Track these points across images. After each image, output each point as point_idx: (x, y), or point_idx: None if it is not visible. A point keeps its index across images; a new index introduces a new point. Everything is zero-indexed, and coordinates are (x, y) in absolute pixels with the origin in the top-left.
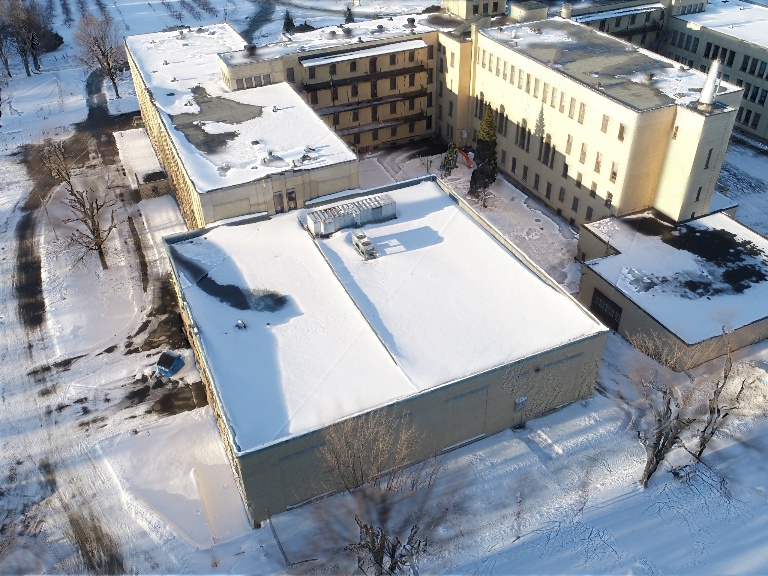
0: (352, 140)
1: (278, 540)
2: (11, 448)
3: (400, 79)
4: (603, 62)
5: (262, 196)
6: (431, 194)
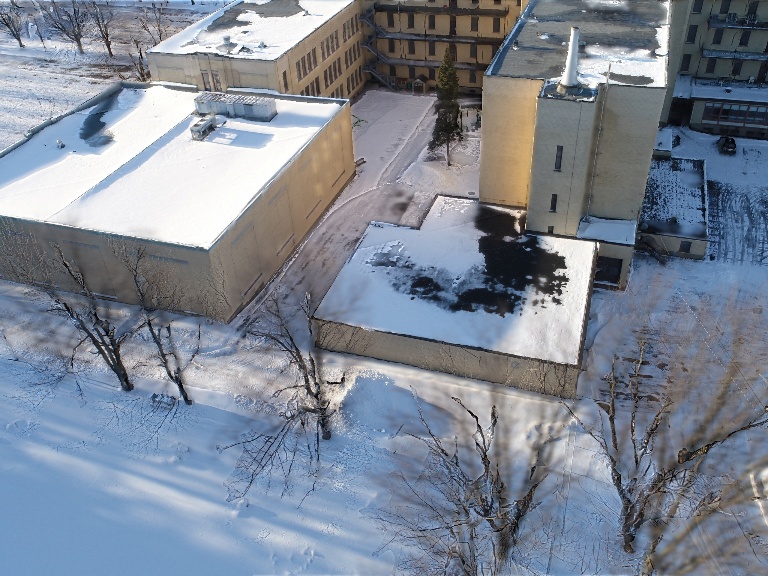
0: (427, 74)
1: None
2: None
3: (482, 21)
4: (588, 28)
5: (193, 70)
6: (322, 114)
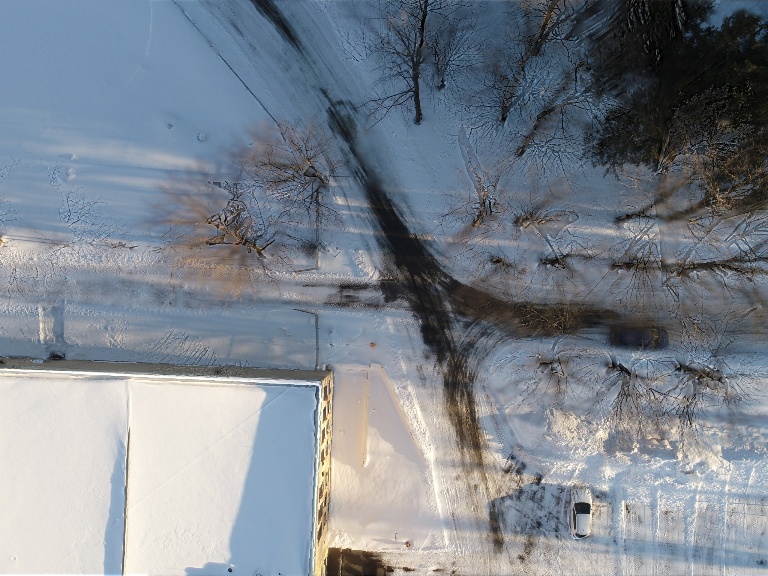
0: None
1: (317, 344)
2: None
3: None
4: None
5: None
6: None
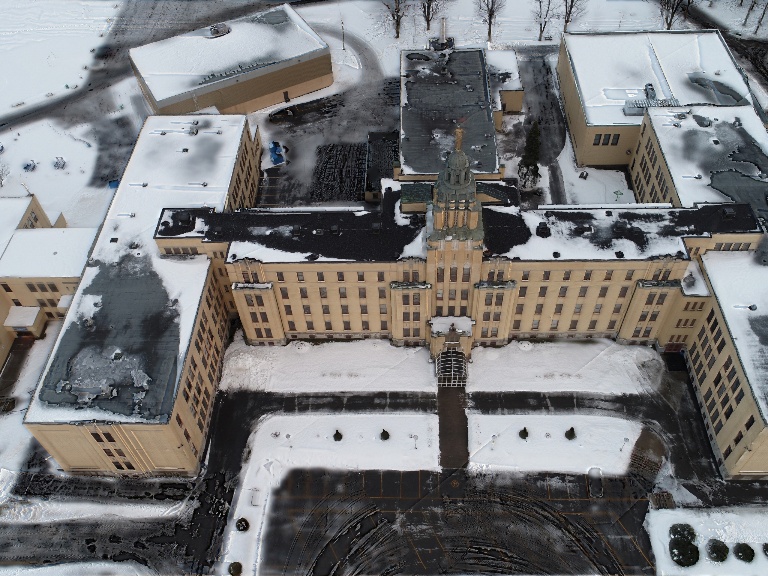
0: None
1: None
2: None
3: None
4: (447, 98)
5: None
6: (596, 116)
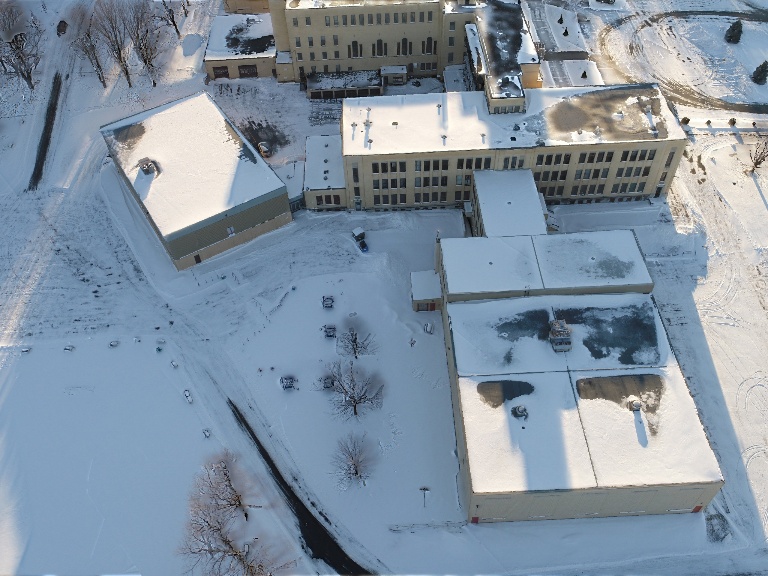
0: None
1: None
2: None
3: None
4: None
5: None
6: None
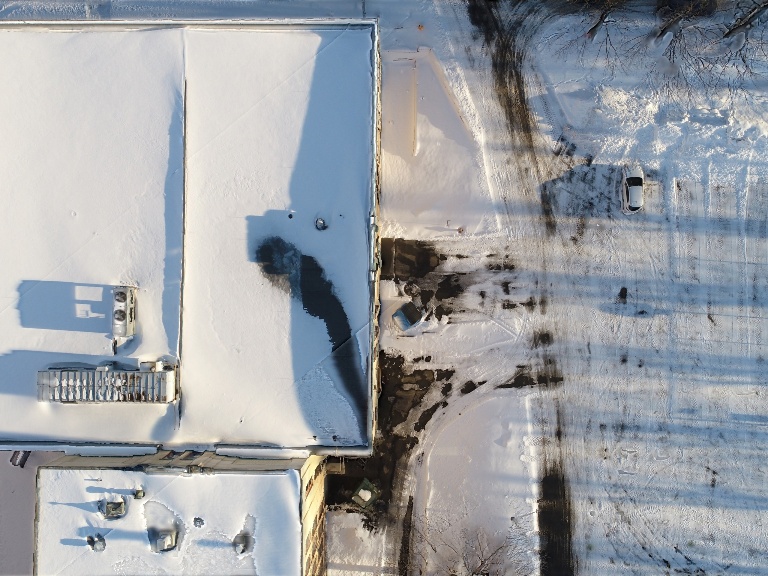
0: None
1: None
2: (582, 265)
3: None
4: None
5: None
6: None
